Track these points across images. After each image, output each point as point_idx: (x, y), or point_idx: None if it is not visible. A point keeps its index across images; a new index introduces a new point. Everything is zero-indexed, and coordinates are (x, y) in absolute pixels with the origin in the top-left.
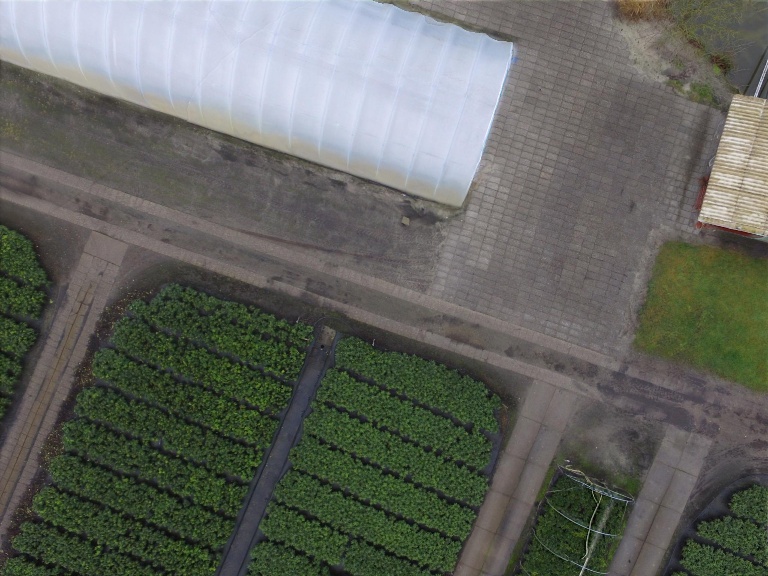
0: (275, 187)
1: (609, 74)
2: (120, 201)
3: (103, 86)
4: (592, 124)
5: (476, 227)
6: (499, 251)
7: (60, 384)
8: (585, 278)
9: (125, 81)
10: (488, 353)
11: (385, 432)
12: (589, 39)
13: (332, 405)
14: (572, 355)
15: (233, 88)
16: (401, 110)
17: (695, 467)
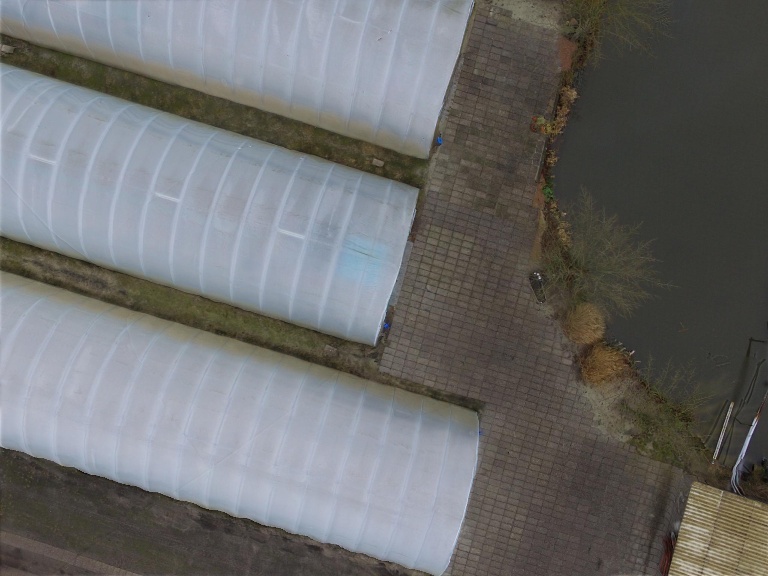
0: (254, 555)
1: (574, 436)
2: (104, 573)
3: None
4: (559, 485)
5: None
6: None
7: None
8: None
9: None
10: None
11: None
12: (554, 402)
13: None
14: None
15: (209, 496)
16: (372, 522)
17: None
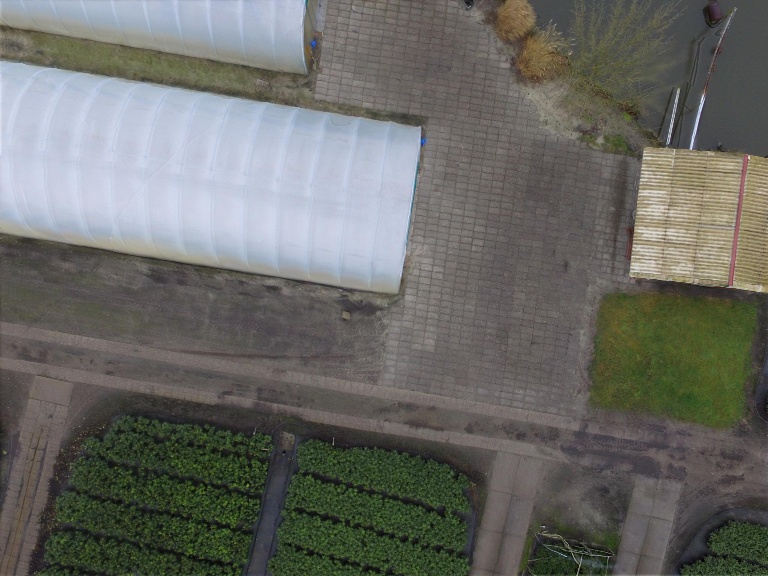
0: (211, 303)
1: (523, 139)
2: (58, 341)
3: (23, 231)
4: (514, 191)
5: (417, 310)
6: (443, 330)
7: (27, 534)
8: (532, 343)
9: (42, 227)
10: (448, 433)
11: (359, 529)
12: (498, 108)
13: (302, 510)
14: (531, 422)
15: (150, 221)
16: (319, 219)
17: (669, 512)
